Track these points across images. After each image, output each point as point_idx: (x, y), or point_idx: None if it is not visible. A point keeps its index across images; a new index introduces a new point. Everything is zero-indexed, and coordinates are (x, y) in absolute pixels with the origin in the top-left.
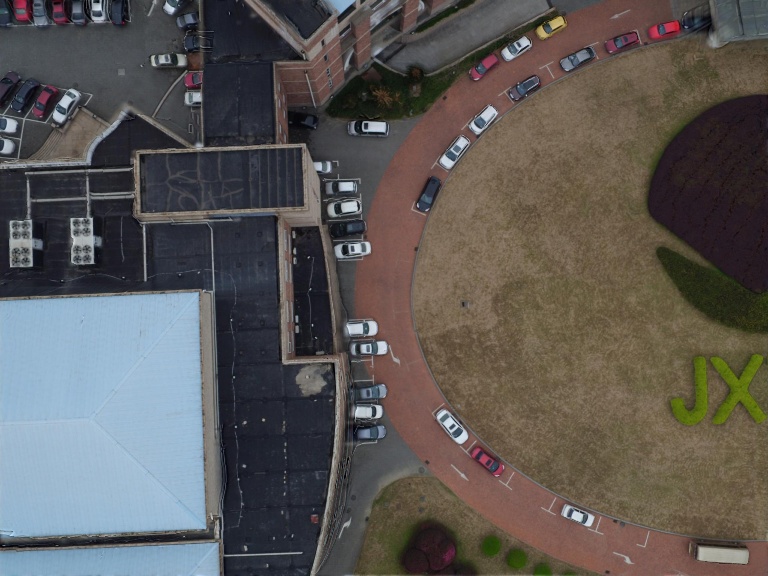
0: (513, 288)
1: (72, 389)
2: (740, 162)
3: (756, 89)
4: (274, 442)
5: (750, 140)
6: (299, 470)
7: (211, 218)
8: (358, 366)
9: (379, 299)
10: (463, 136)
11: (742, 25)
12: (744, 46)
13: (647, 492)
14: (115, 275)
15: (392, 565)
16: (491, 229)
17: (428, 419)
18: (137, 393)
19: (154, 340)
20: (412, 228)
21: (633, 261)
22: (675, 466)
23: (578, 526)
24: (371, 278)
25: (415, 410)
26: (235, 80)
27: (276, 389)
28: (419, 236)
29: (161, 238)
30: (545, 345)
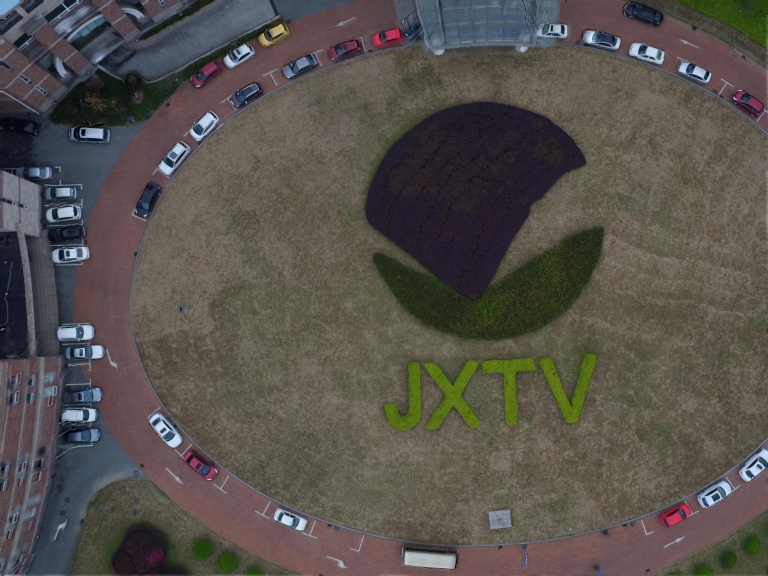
0: (230, 293)
1: None
2: (457, 169)
3: (479, 96)
4: None
5: (468, 147)
6: None
7: None
8: (75, 370)
9: (98, 304)
10: (180, 142)
11: (444, 33)
12: (466, 54)
13: (361, 496)
14: None
15: (106, 567)
16: (210, 235)
17: (144, 423)
18: None
19: None
20: (132, 233)
21: (350, 267)
22: (389, 471)
23: (291, 530)
24: (90, 283)
25: (131, 414)
26: None
27: None
28: (139, 241)
29: None
30: (261, 350)
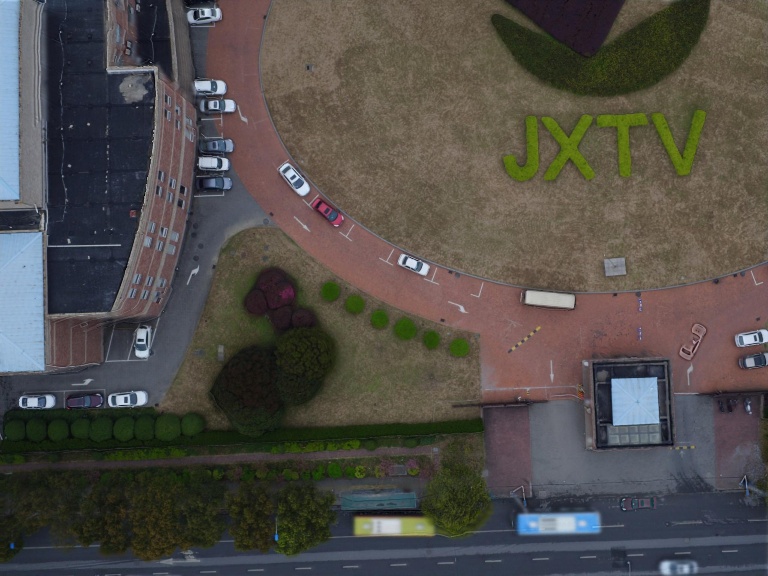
0: (355, 53)
1: None
2: None
3: None
4: (98, 144)
5: None
6: (120, 170)
7: None
8: (208, 124)
9: (229, 63)
10: None
11: None
12: None
13: (481, 245)
14: None
15: (237, 311)
16: None
17: (273, 174)
18: None
19: None
20: None
21: (469, 28)
22: (508, 220)
23: (414, 276)
24: (222, 44)
25: (261, 165)
26: None
27: (101, 96)
28: (268, 5)
29: None
30: (385, 106)
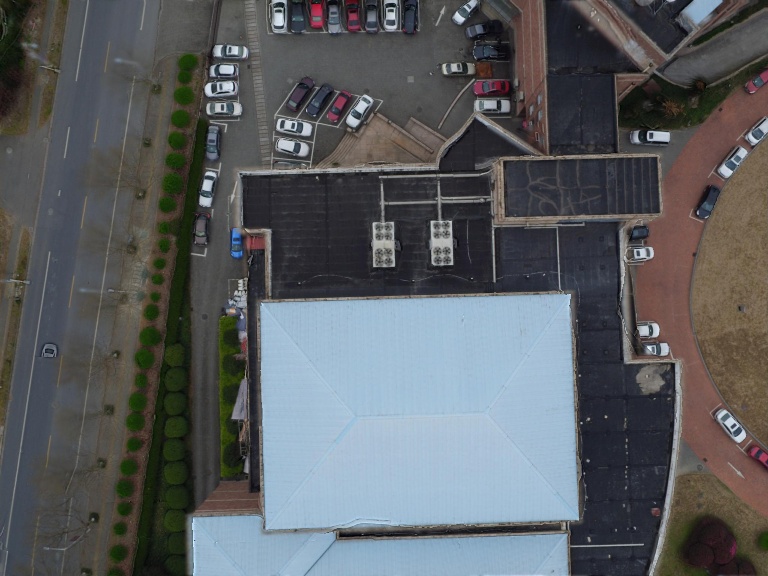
0: None
1: (464, 385)
2: None
3: None
4: (616, 438)
5: None
6: (639, 465)
7: (566, 223)
8: None
9: (659, 302)
10: (742, 147)
11: None
12: None
13: None
14: (463, 276)
15: (671, 559)
16: (766, 236)
17: (706, 418)
18: (523, 389)
19: (535, 339)
20: (690, 234)
21: None
22: None
23: None
24: (651, 282)
25: (694, 410)
26: (578, 91)
27: (617, 387)
28: (697, 242)
29: (508, 241)
30: None
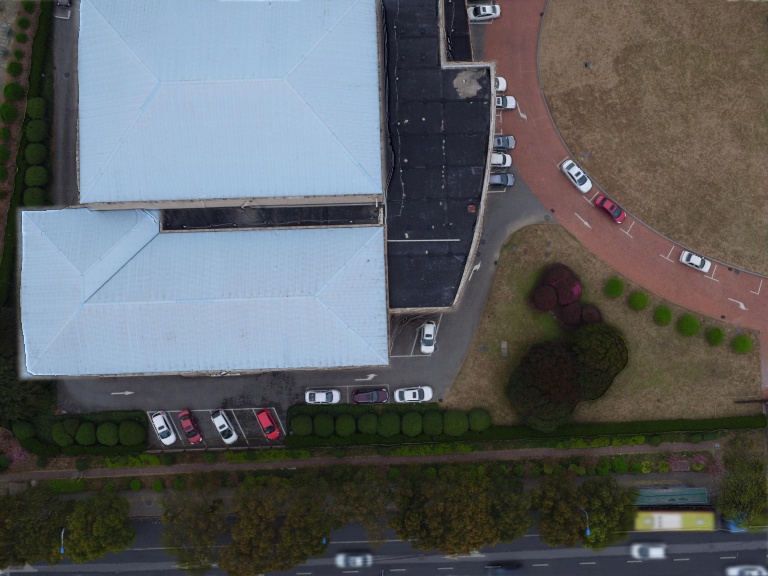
0: (633, 51)
1: (265, 55)
2: None
3: None
4: (433, 139)
5: None
6: (456, 166)
7: None
8: None
9: (507, 60)
10: None
11: None
12: None
13: (760, 242)
14: None
15: (519, 306)
16: None
17: (553, 171)
18: (324, 62)
19: (338, 17)
20: None
21: (745, 28)
22: None
23: (695, 273)
24: (500, 41)
25: (541, 162)
26: None
27: (435, 92)
28: (544, 3)
29: None
30: (663, 104)
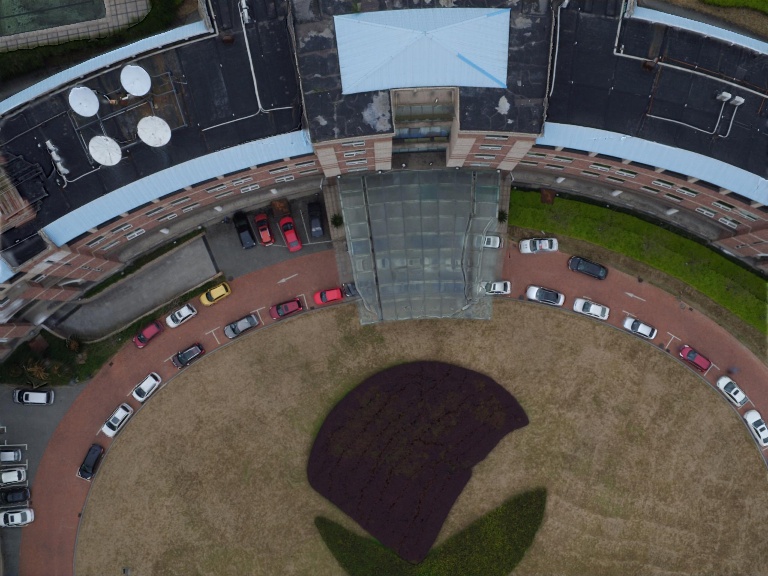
0: (173, 555)
1: None
2: (399, 432)
3: (422, 354)
4: None
5: (410, 409)
6: None
7: None
8: None
9: (42, 565)
10: (123, 407)
11: (381, 310)
12: None
13: None
14: None
15: None
16: (153, 496)
17: None
18: None
19: None
20: (76, 494)
21: (292, 529)
22: None
23: None
24: (35, 544)
25: None
26: None
27: None
28: (83, 502)
29: None
30: None
